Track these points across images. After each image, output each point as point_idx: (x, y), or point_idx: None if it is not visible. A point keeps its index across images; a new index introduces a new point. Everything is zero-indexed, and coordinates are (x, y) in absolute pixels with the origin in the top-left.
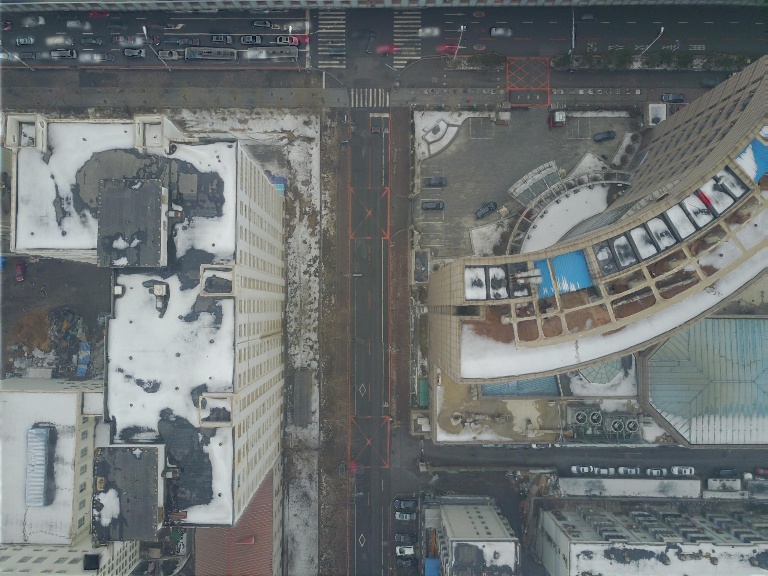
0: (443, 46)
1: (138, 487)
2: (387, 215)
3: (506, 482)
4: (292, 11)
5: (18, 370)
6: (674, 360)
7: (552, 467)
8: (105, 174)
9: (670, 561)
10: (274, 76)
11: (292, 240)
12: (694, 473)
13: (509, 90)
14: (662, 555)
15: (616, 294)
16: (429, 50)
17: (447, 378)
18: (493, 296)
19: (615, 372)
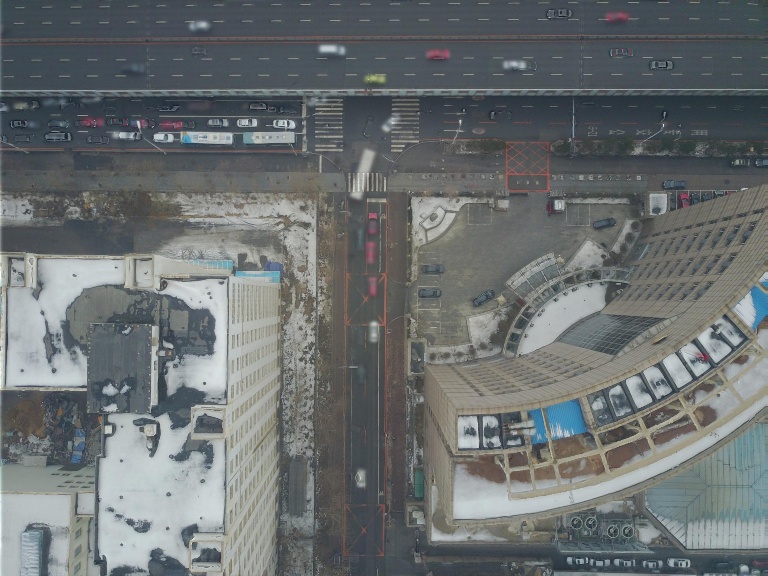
0: (441, 130)
1: None
2: (384, 302)
3: (501, 572)
4: None
5: (13, 456)
6: None
7: (547, 558)
8: (95, 310)
9: None
10: (270, 160)
11: (288, 326)
12: (690, 566)
13: (508, 175)
14: None
15: (611, 444)
16: (427, 134)
17: None
18: (486, 445)
19: None
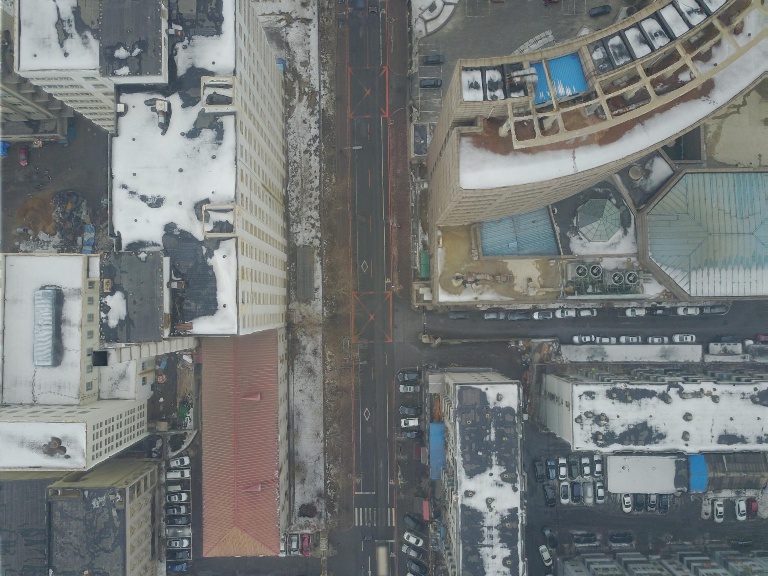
0: None
1: (144, 289)
2: (386, 94)
3: (509, 354)
4: None
5: None
6: (673, 214)
7: (554, 337)
8: None
9: (672, 399)
10: None
11: (292, 120)
12: (695, 340)
13: None
14: (664, 394)
15: (611, 93)
16: None
17: (448, 240)
18: (490, 98)
19: (614, 229)
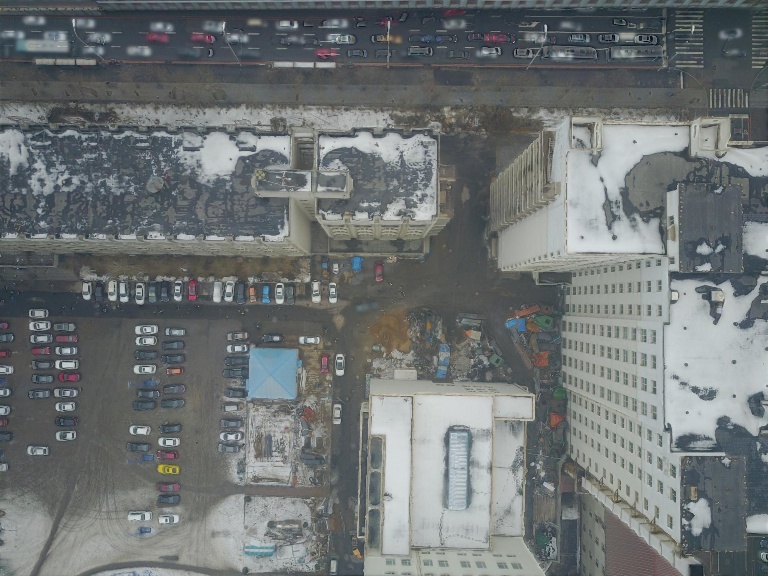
0: None
1: (729, 497)
2: None
3: None
4: (651, 9)
5: (378, 371)
6: None
7: None
8: (655, 177)
9: None
10: None
11: None
12: None
13: None
14: None
15: None
16: None
17: None
18: None
19: None
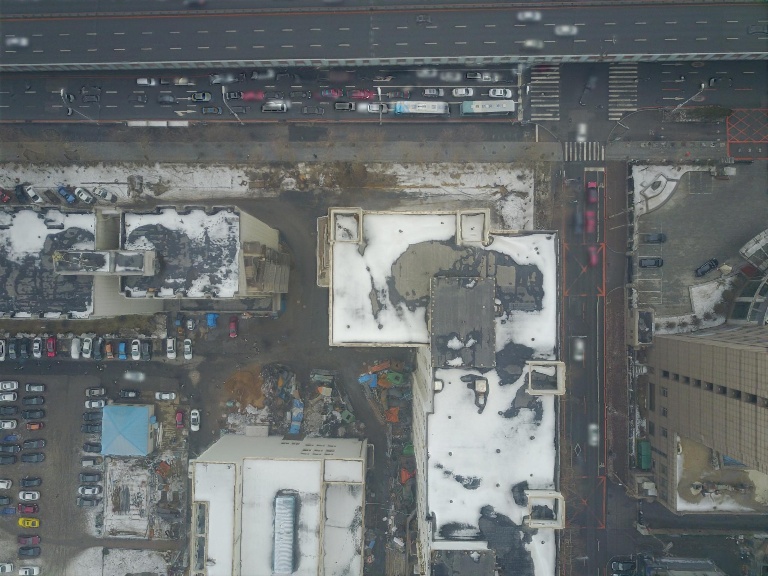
0: (660, 97)
1: None
2: (602, 272)
3: (726, 545)
4: (505, 63)
5: (232, 426)
6: None
7: None
8: (421, 266)
9: None
10: (486, 129)
11: None
12: None
13: (729, 143)
14: None
15: None
16: (645, 102)
17: (687, 447)
18: None
19: None
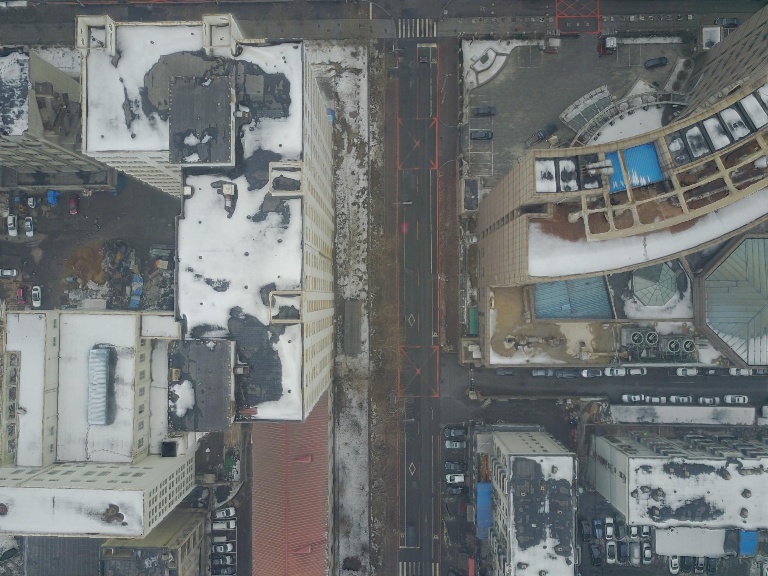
0: None
1: (212, 379)
2: (435, 146)
3: (556, 411)
4: None
5: (73, 302)
6: (732, 280)
7: (603, 395)
8: None
9: (730, 475)
10: (321, 8)
11: (340, 172)
12: (747, 401)
13: (558, 18)
14: (722, 470)
15: None
16: None
17: (500, 301)
18: (563, 189)
19: (670, 294)
